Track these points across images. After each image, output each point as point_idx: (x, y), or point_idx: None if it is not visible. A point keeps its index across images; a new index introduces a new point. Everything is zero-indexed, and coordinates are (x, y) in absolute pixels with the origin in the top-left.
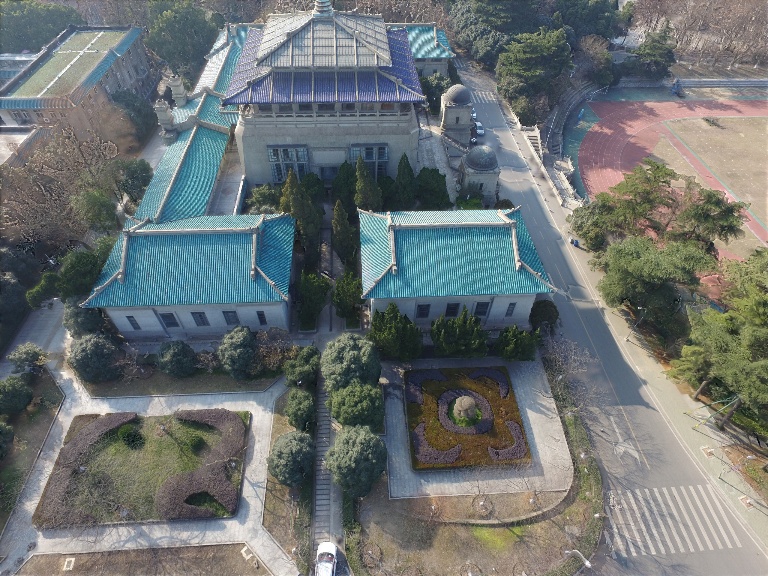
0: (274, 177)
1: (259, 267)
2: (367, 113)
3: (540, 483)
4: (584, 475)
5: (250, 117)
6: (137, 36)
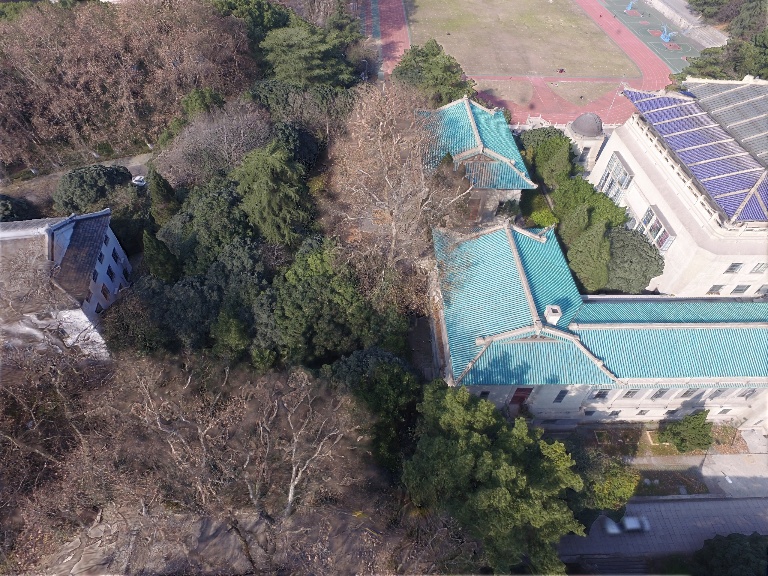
0: None
1: None
2: None
3: None
4: None
5: None
6: None
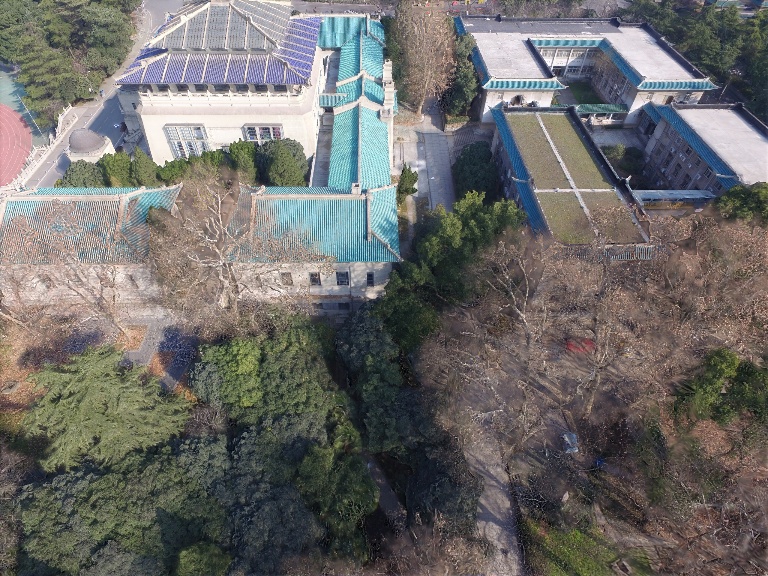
0: None
1: None
2: None
3: None
4: None
5: None
6: None
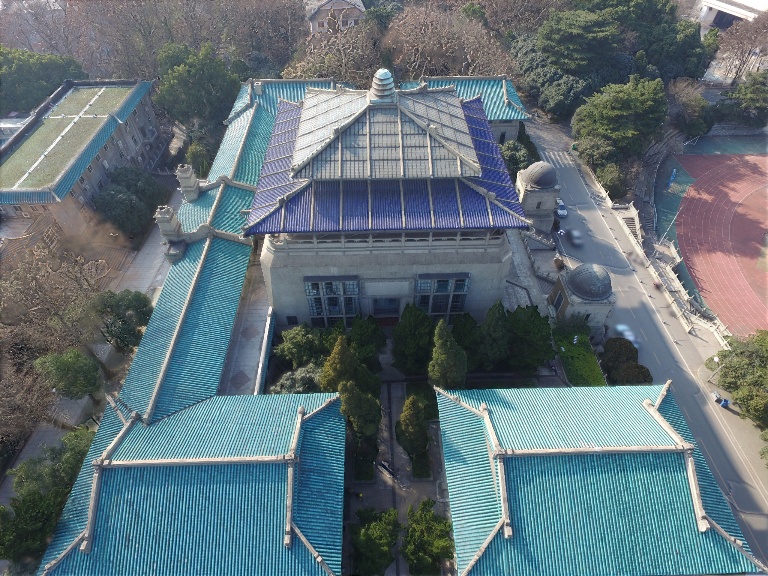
0: (311, 311)
1: (297, 522)
2: (443, 237)
3: None
4: None
5: (282, 243)
6: (144, 92)
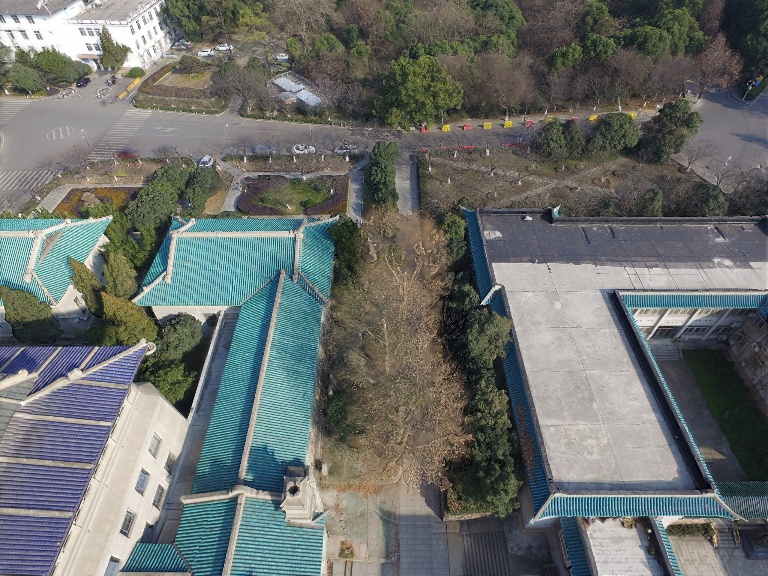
0: None
1: None
2: None
3: (77, 187)
4: (48, 192)
5: None
6: None
